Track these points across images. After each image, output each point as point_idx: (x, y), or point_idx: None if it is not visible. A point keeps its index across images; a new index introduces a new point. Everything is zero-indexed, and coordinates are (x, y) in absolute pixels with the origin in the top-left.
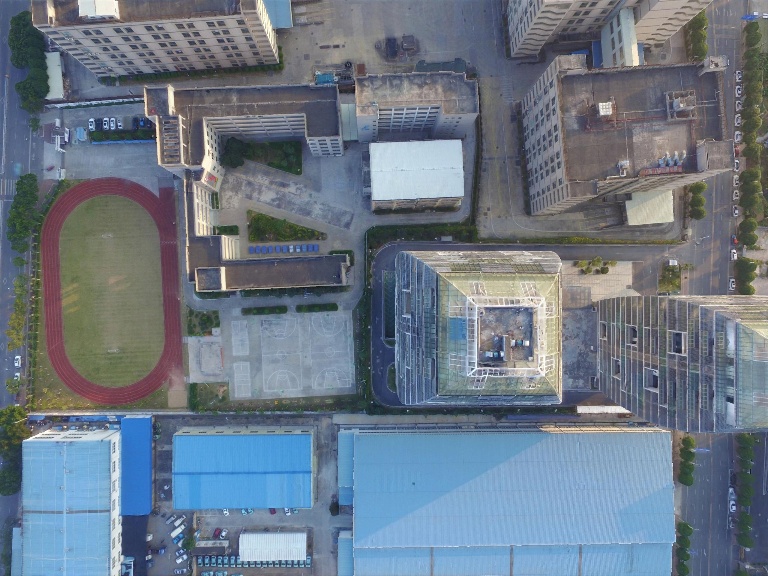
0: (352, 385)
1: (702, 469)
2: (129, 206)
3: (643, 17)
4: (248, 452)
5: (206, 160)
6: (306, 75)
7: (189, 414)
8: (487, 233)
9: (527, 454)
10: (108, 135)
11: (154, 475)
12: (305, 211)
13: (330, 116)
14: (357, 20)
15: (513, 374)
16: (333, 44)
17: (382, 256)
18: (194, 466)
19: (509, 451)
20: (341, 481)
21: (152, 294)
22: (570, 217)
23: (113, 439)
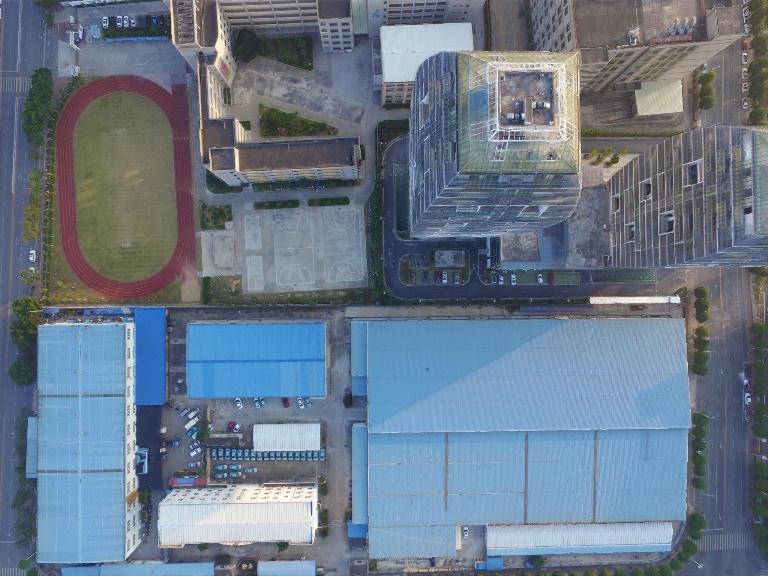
0: (364, 278)
1: (716, 362)
2: (142, 103)
3: None
4: (262, 340)
5: (219, 43)
6: None
7: (202, 306)
8: None
9: (540, 340)
10: (121, 33)
11: (168, 368)
12: (316, 106)
13: None
14: None
15: (534, 137)
16: None
17: (393, 150)
18: (208, 354)
19: (522, 337)
20: (355, 370)
21: (165, 189)
22: None
23: (128, 325)
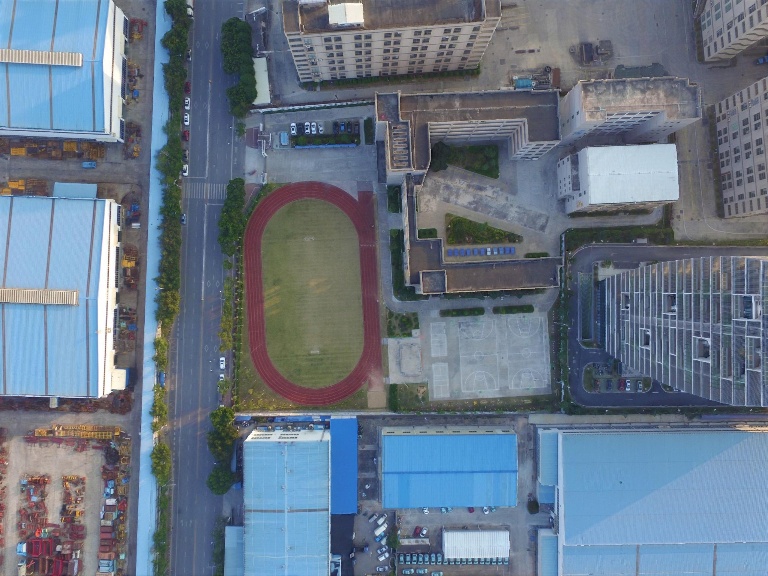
0: (548, 385)
1: None
2: (329, 209)
3: None
4: (455, 452)
5: None
6: (502, 80)
7: (391, 414)
8: (680, 235)
9: (730, 453)
10: (309, 139)
11: None
12: (501, 214)
13: (550, 121)
14: (552, 25)
15: None
16: (528, 49)
17: (578, 258)
18: (403, 465)
19: (712, 450)
20: (545, 480)
21: (352, 296)
22: (761, 219)
23: (329, 439)
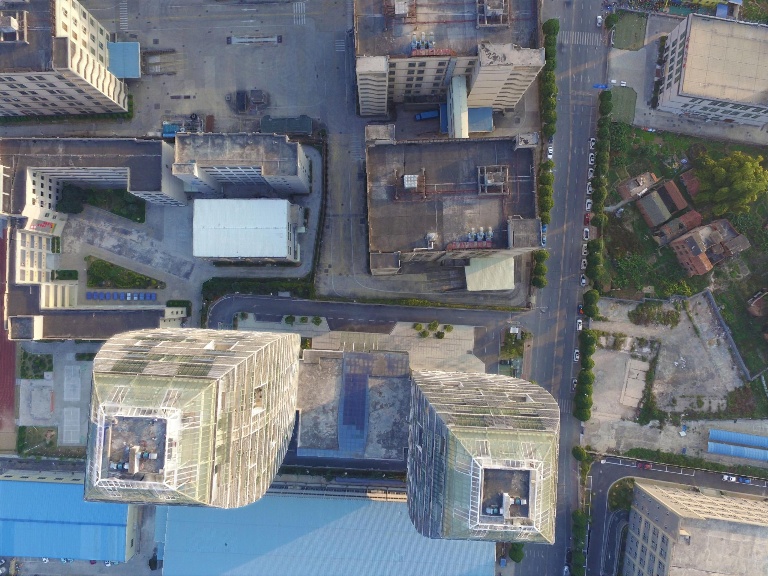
0: None
1: None
2: None
3: (473, 86)
4: (65, 501)
5: (29, 209)
6: (155, 124)
7: (14, 457)
8: (327, 290)
9: (345, 521)
10: None
11: None
12: (146, 259)
13: (154, 171)
14: (209, 72)
15: (140, 487)
16: (184, 95)
17: (219, 308)
18: (9, 512)
19: (327, 516)
20: (157, 536)
21: None
22: (413, 278)
23: None
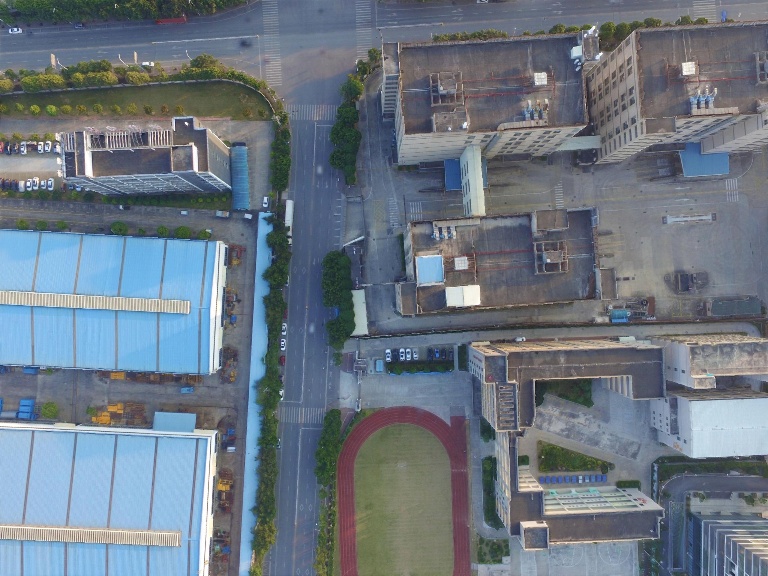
0: None
1: None
2: (421, 434)
3: None
4: None
5: None
6: (596, 307)
7: None
8: None
9: None
10: (404, 366)
11: None
12: (593, 441)
13: (654, 377)
14: (647, 253)
15: None
16: (623, 276)
17: (670, 488)
18: None
19: None
20: None
21: (443, 521)
22: None
23: None
